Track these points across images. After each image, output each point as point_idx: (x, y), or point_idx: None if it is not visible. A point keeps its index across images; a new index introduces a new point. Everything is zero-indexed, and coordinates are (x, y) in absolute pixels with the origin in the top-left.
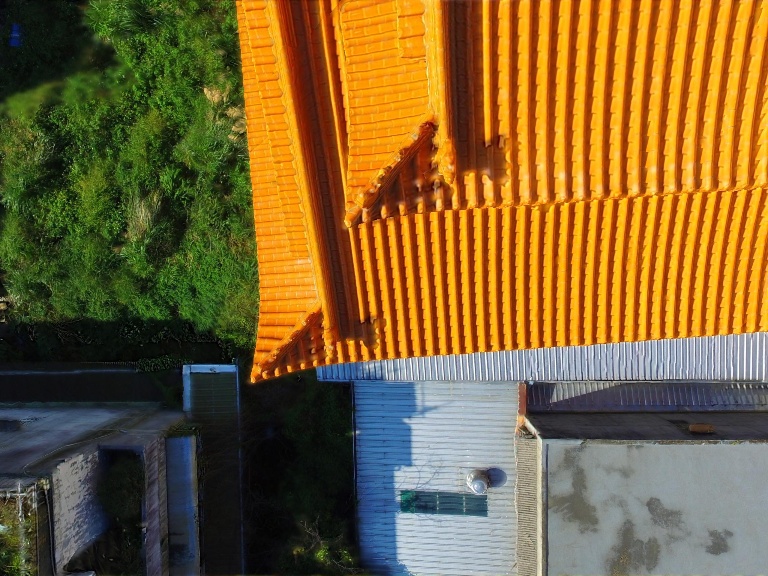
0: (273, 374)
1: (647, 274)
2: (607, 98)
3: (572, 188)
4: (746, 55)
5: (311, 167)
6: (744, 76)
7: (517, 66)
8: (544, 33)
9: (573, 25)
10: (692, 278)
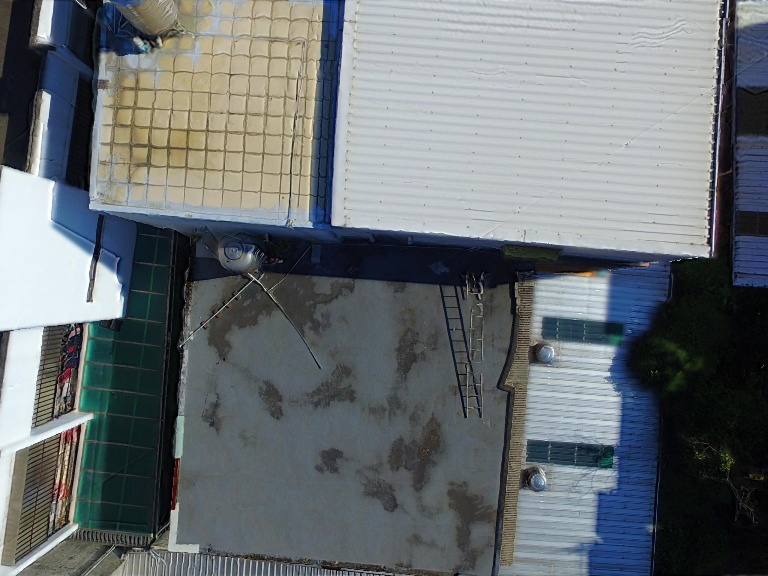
0: None
1: None
2: None
3: None
4: None
5: None
6: None
7: None
8: None
9: None
10: None
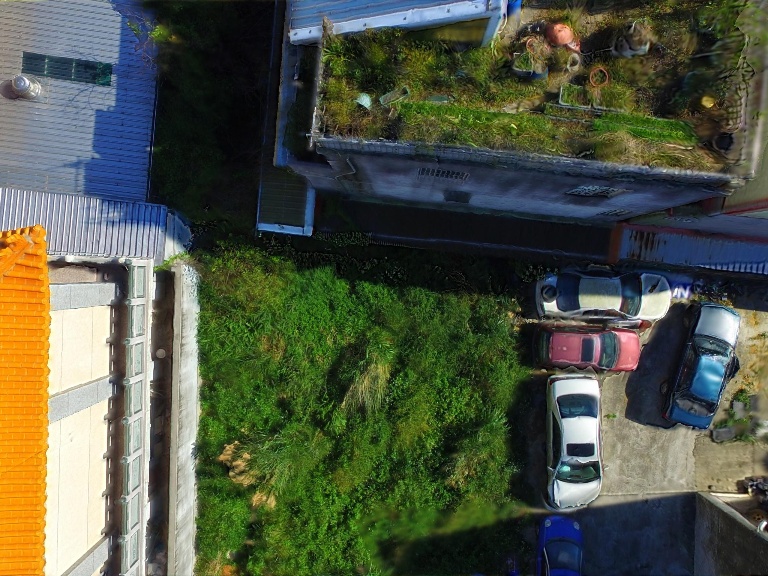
0: None
1: None
2: None
3: None
4: None
5: None
6: None
7: None
8: None
9: None
10: None
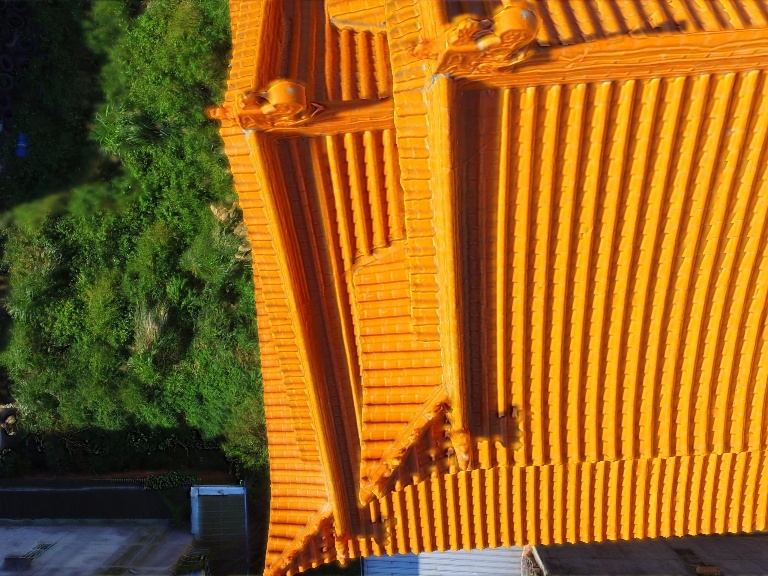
0: (285, 575)
1: (657, 479)
2: (620, 375)
3: (585, 452)
4: (759, 340)
5: (323, 397)
6: (756, 357)
7: (530, 349)
8: (558, 324)
9: (586, 317)
10: (702, 482)
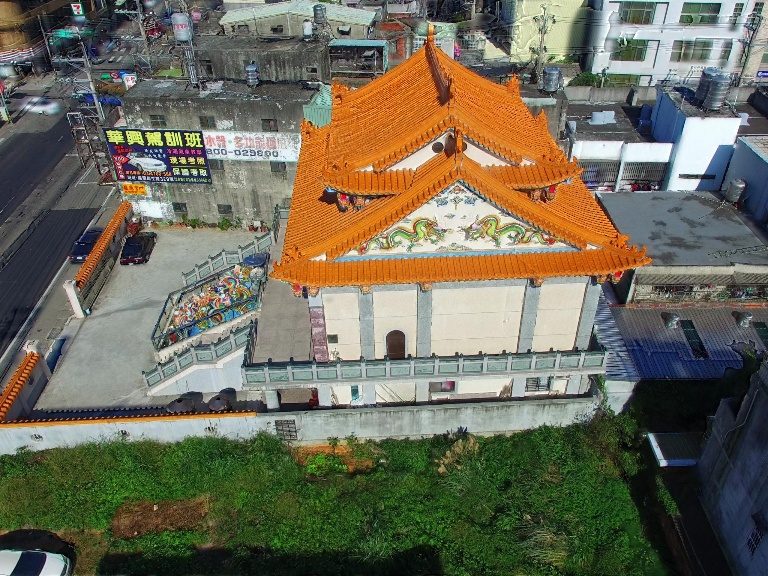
0: None
1: None
2: None
3: None
4: None
5: None
6: None
7: None
8: None
9: None
10: None
